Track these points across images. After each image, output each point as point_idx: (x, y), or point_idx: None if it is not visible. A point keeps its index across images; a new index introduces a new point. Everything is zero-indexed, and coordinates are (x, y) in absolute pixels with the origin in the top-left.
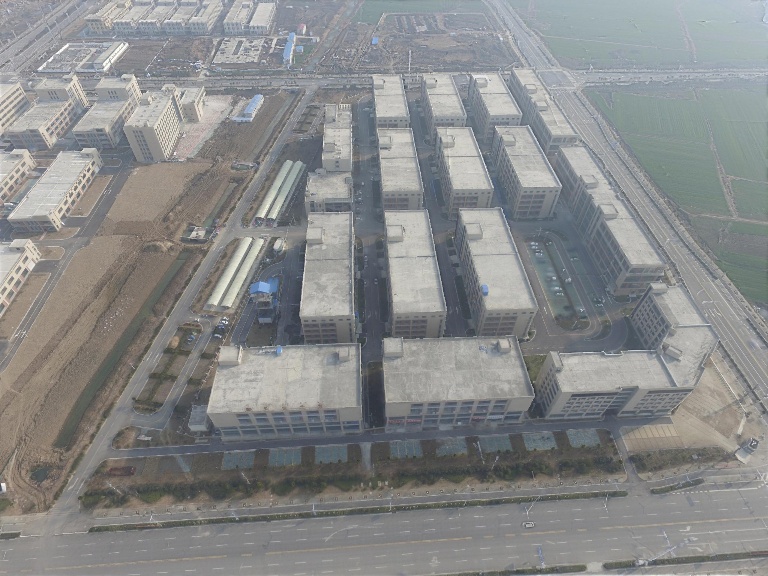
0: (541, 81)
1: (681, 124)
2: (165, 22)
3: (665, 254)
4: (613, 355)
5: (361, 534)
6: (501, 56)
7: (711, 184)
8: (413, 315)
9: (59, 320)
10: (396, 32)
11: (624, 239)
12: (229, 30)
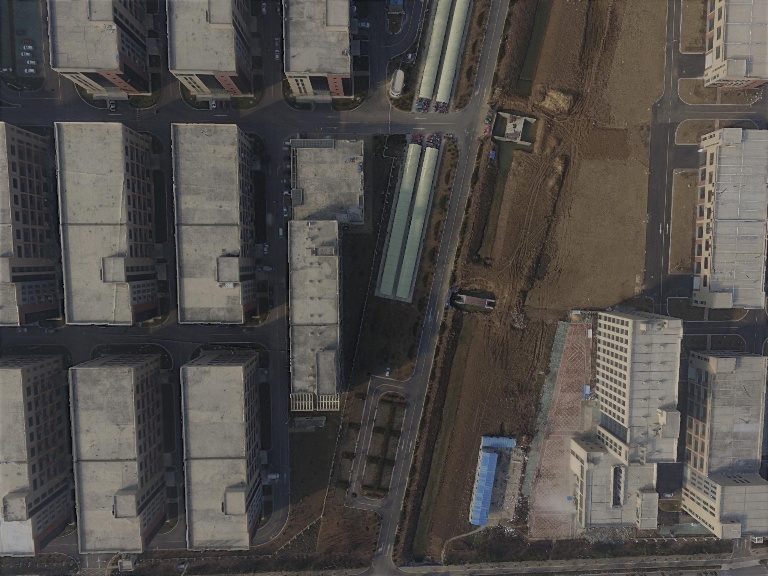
0: None
1: None
2: None
3: None
4: None
5: None
6: None
7: None
8: None
9: None
10: None
11: None
12: None
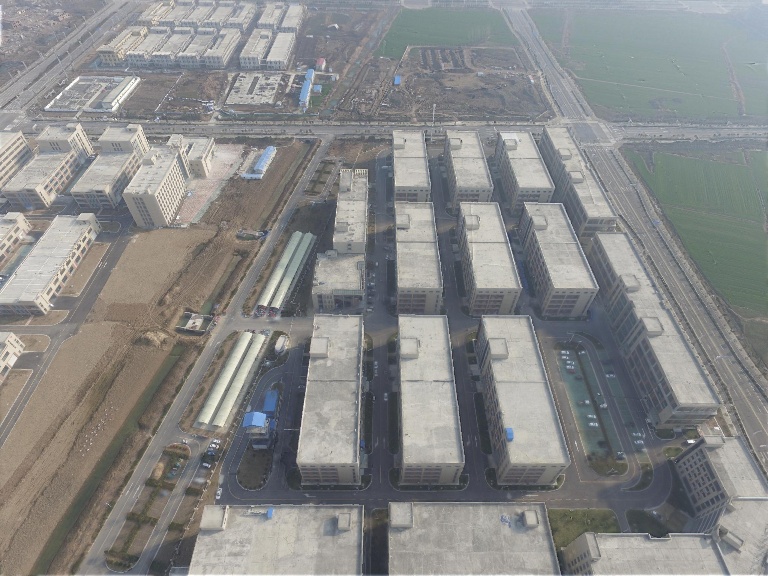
0: (576, 143)
1: (730, 196)
2: (179, 55)
3: (714, 372)
4: (660, 539)
5: None
6: (532, 102)
7: (765, 277)
8: (426, 465)
9: (36, 433)
10: (420, 69)
11: (670, 365)
12: (245, 64)
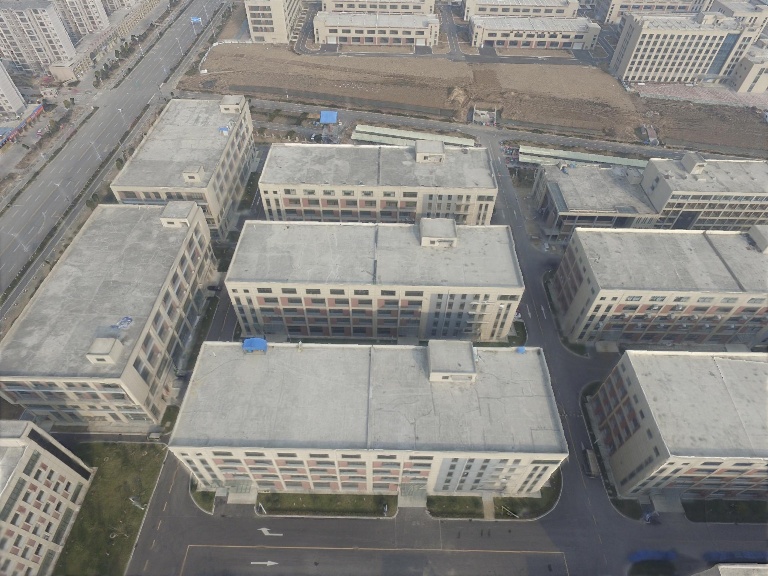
0: None
1: None
2: None
3: None
4: None
5: (28, 235)
6: None
7: None
8: None
9: (357, 66)
10: None
11: None
12: None
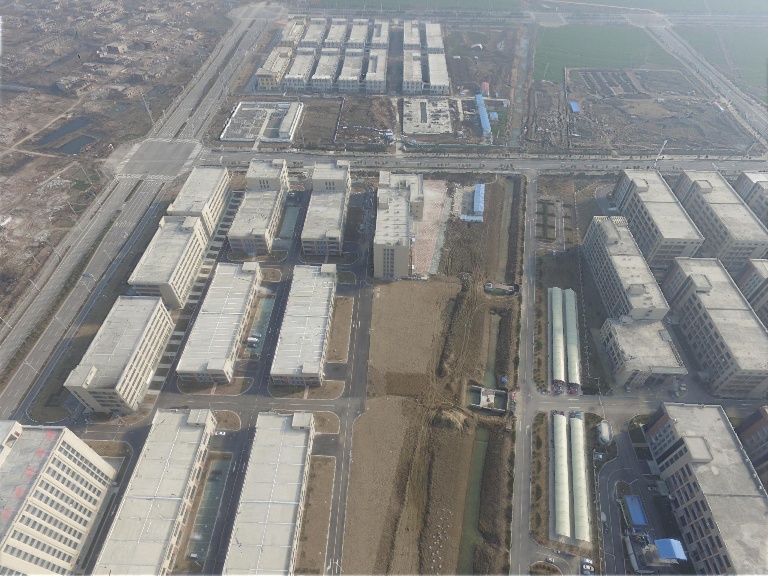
0: None
1: None
2: (340, 79)
3: None
4: None
5: None
6: (733, 133)
7: None
8: None
9: (371, 542)
10: (590, 94)
11: None
12: (407, 89)
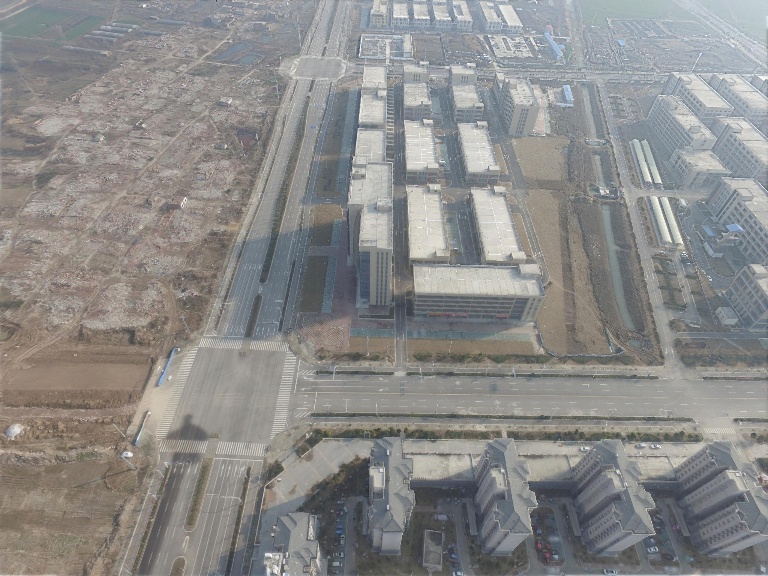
0: None
1: None
2: (437, 19)
3: None
4: None
5: None
6: (742, 61)
7: None
8: None
9: (556, 247)
10: None
11: None
12: (489, 28)
